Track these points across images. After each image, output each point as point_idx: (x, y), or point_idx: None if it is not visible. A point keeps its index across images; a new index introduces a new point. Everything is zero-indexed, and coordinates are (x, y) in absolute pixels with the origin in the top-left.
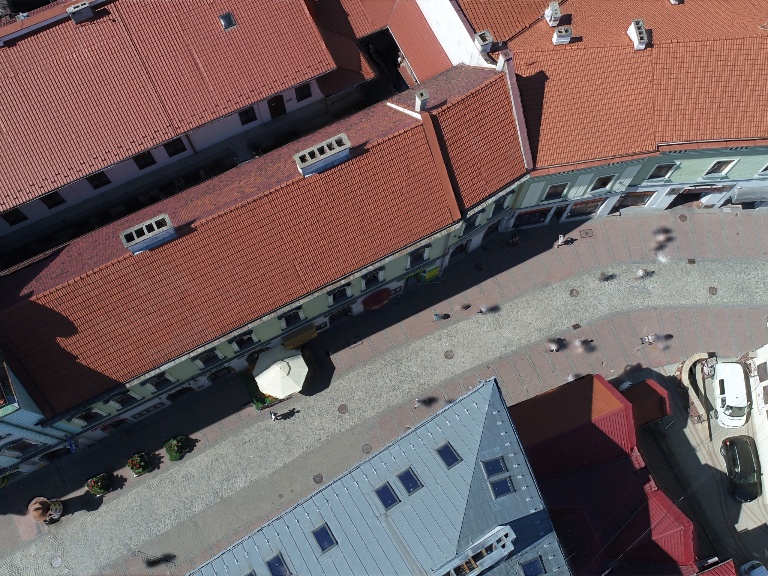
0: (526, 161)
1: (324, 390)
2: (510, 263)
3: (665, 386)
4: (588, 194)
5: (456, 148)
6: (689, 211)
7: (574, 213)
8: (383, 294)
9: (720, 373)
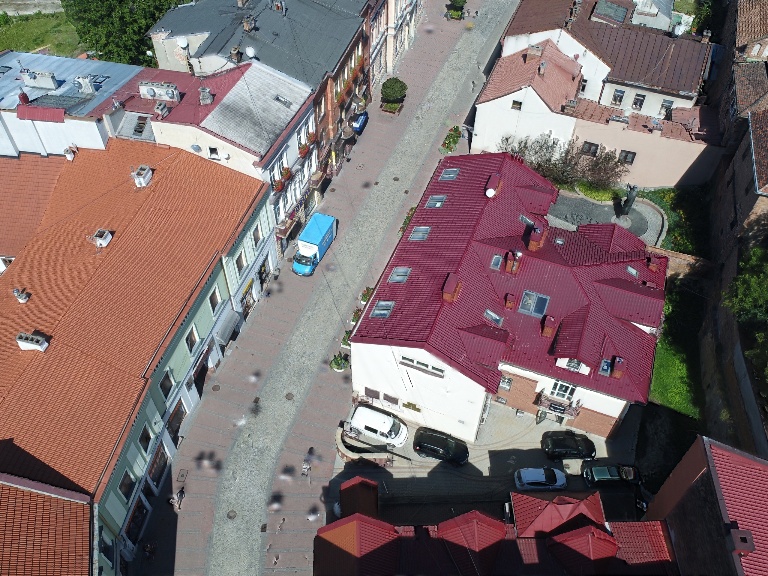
0: (79, 501)
1: None
2: (169, 565)
3: (352, 475)
4: (148, 457)
5: (16, 569)
6: (213, 381)
7: (157, 478)
8: None
9: (359, 426)
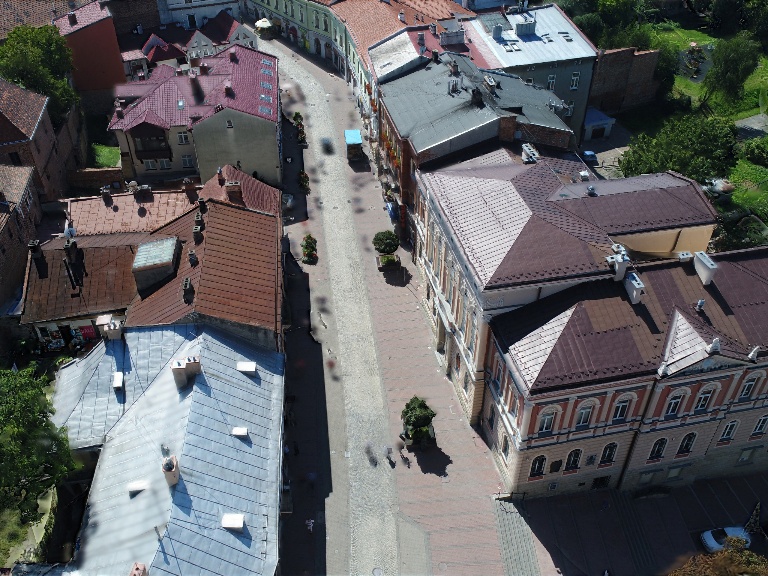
0: None
1: (262, 39)
2: (319, 65)
3: None
4: None
5: None
6: None
7: None
8: (294, 28)
9: None
